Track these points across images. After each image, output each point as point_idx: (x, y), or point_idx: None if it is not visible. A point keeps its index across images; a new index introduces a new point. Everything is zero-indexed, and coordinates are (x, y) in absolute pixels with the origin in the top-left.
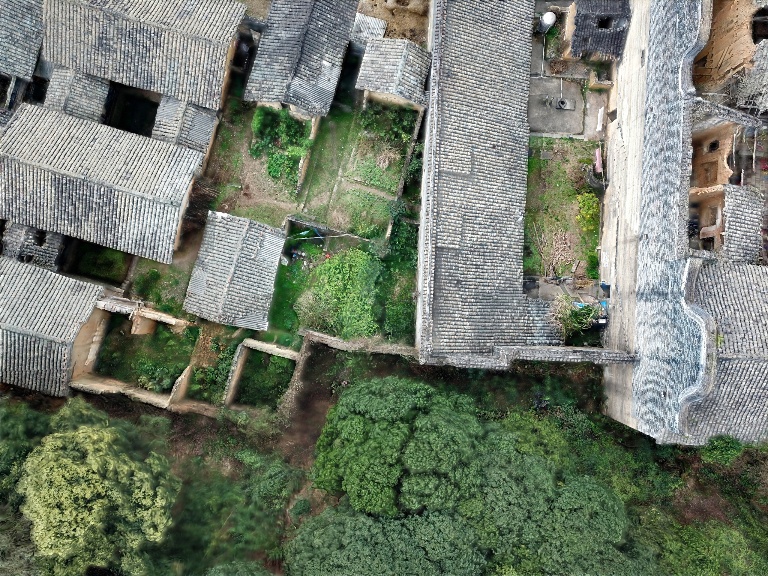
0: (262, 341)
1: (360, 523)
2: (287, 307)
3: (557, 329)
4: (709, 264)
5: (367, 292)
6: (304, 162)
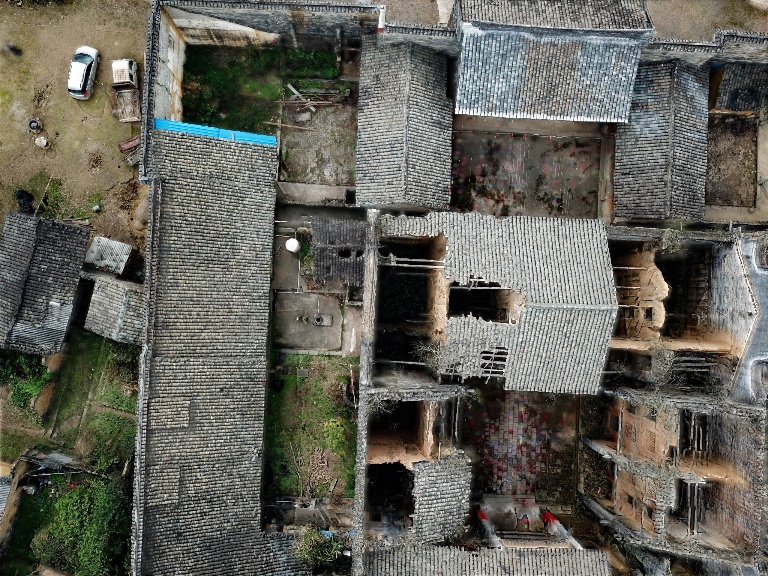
0: None
1: None
2: (33, 537)
3: (304, 559)
4: (395, 549)
5: (97, 536)
6: (37, 400)
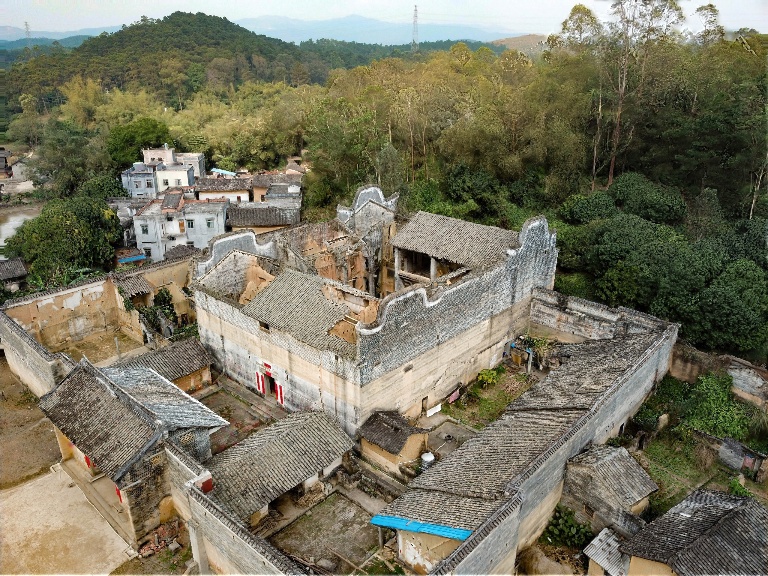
0: None
1: (762, 255)
2: None
3: None
4: None
5: None
6: None
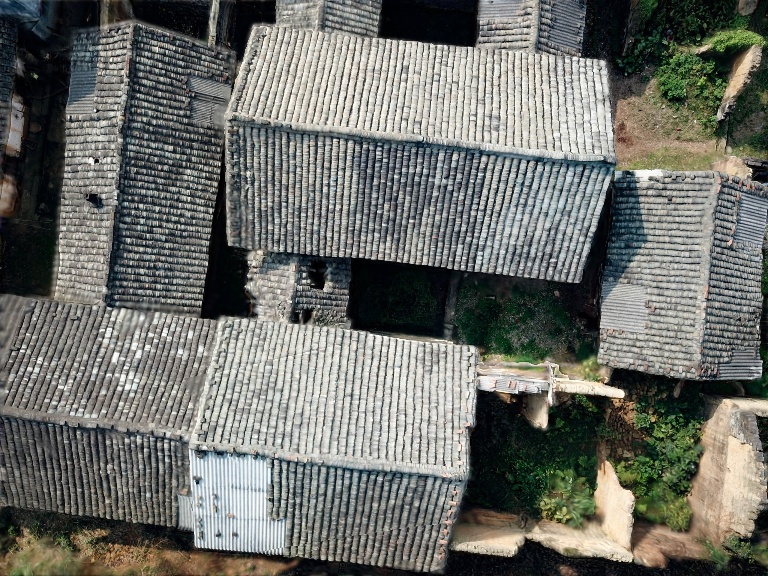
0: (748, 397)
1: None
2: None
3: None
4: None
5: None
6: None
